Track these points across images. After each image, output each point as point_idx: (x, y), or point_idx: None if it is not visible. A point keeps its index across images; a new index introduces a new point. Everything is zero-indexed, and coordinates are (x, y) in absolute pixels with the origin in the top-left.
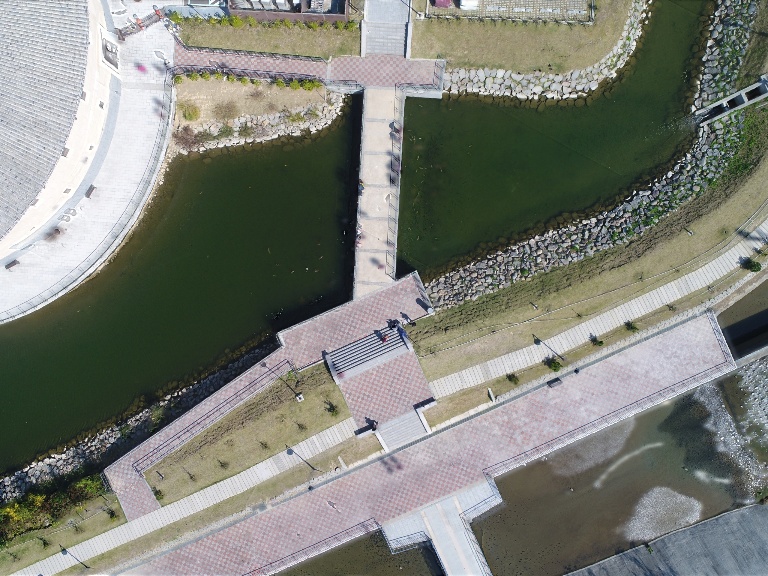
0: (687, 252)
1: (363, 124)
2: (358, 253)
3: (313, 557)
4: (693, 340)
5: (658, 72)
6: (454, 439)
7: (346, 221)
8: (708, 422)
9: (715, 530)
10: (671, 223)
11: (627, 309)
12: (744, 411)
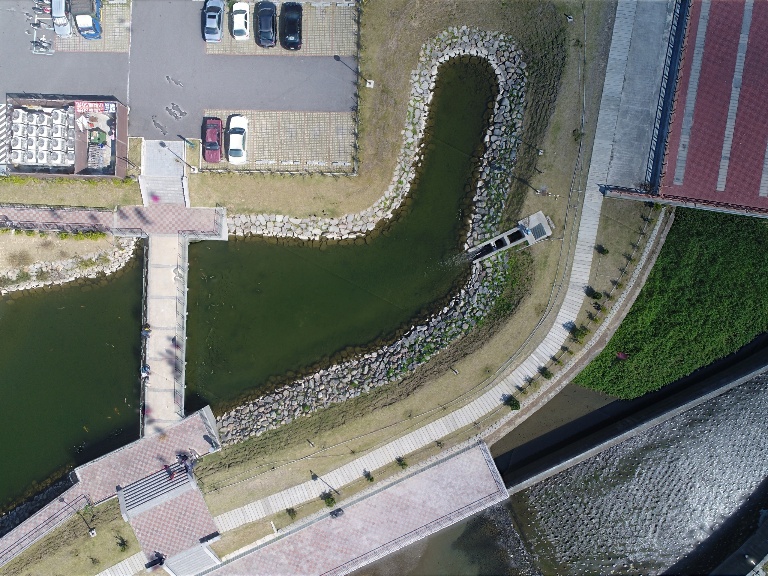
0: (453, 390)
1: (149, 270)
2: (147, 392)
3: None
4: (467, 471)
5: (434, 210)
6: (244, 568)
7: None
8: (498, 540)
9: None
10: (440, 361)
11: (398, 445)
12: (532, 529)
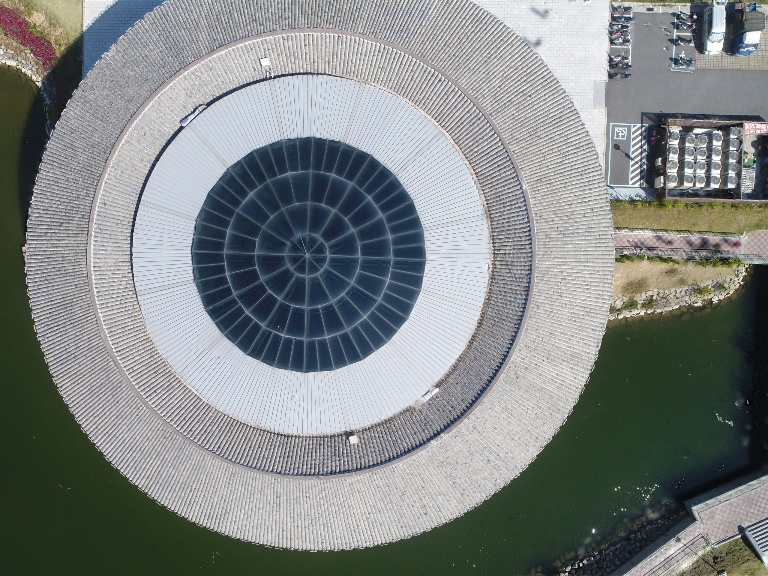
0: None
1: None
2: None
3: None
4: None
5: None
6: None
7: (749, 390)
8: None
9: None
10: None
11: None
12: None
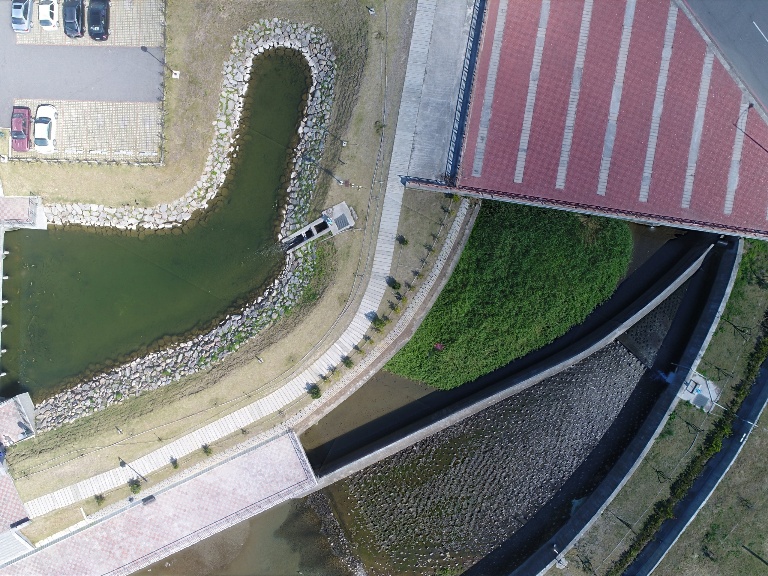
0: (258, 379)
1: None
2: None
3: None
4: (276, 459)
5: (251, 201)
6: (58, 554)
7: None
8: (319, 529)
9: None
10: (247, 350)
11: (204, 433)
12: (351, 518)
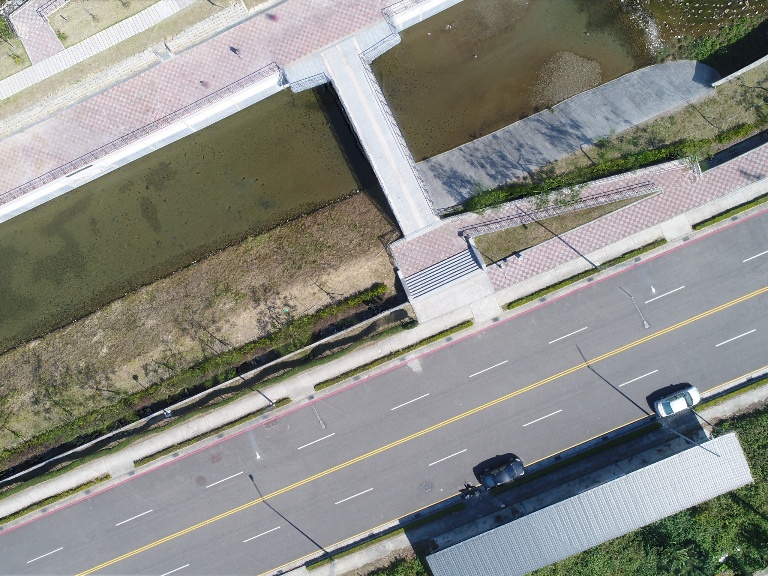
0: None
1: None
2: None
3: (223, 135)
4: None
5: None
6: None
7: None
8: None
9: (616, 87)
10: None
11: None
12: None
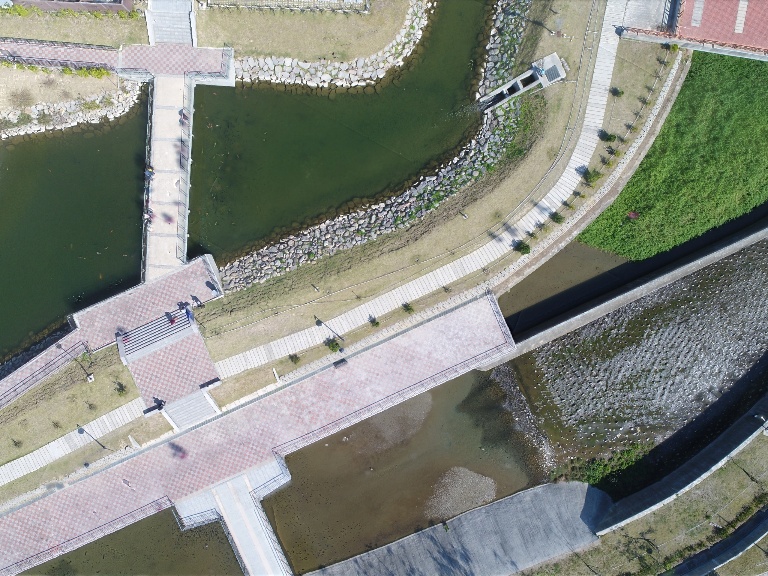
0: (462, 235)
1: (153, 111)
2: (149, 237)
3: (123, 536)
4: (474, 321)
5: (446, 60)
6: (244, 419)
7: None
8: (503, 403)
9: (508, 508)
10: (449, 207)
11: (405, 291)
12: (538, 392)
